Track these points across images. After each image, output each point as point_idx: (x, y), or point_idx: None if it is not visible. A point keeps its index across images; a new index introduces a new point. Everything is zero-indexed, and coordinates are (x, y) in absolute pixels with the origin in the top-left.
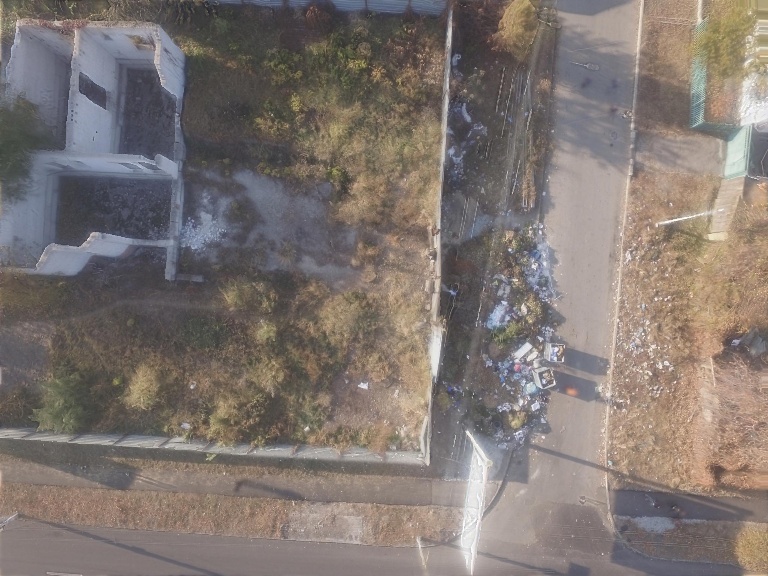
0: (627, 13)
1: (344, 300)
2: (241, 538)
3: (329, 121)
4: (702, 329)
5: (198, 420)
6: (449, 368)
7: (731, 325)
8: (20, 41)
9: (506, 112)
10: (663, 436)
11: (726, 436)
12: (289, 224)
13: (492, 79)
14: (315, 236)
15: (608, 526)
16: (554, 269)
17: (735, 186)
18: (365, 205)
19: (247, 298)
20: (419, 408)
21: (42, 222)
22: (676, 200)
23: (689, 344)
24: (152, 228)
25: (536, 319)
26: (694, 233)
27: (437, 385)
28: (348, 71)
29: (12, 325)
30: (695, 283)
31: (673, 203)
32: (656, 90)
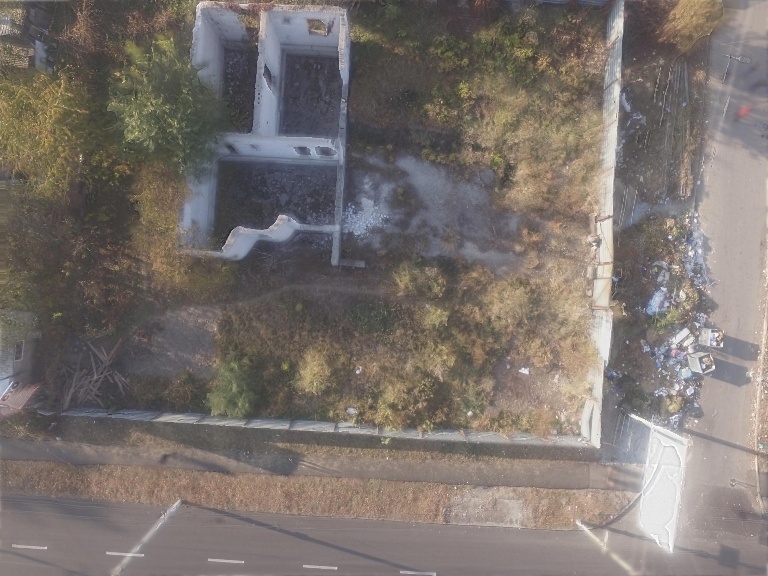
0: None
1: (509, 286)
2: (403, 523)
3: (494, 109)
4: None
5: (364, 405)
6: None
7: None
8: (201, 24)
9: (664, 102)
10: None
11: None
12: (451, 210)
13: (650, 70)
14: (477, 223)
15: (757, 508)
16: (708, 257)
17: None
18: (531, 192)
19: (419, 283)
20: (585, 392)
21: (207, 206)
22: None
23: None
24: (310, 214)
25: (693, 305)
26: None
27: None
28: (514, 60)
29: (176, 310)
30: None
31: None
32: None
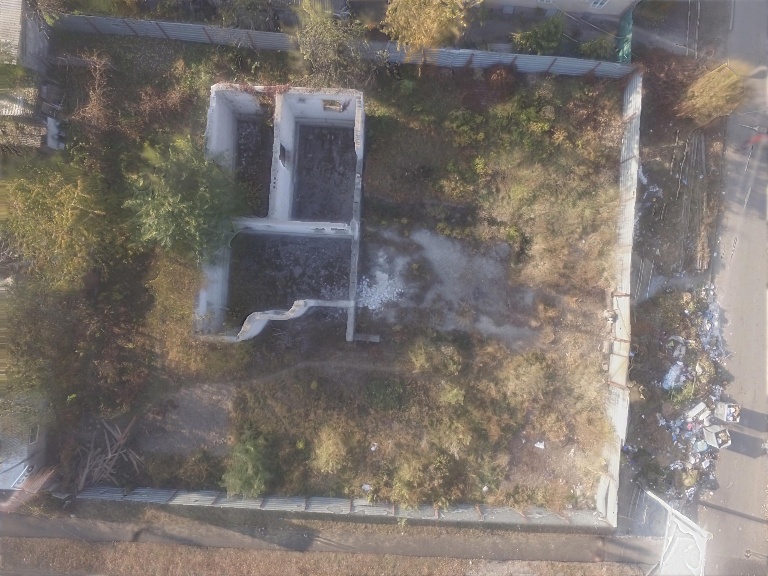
0: None
1: (524, 361)
2: None
3: (510, 183)
4: None
5: (380, 482)
6: None
7: None
8: (215, 105)
9: (680, 174)
10: None
11: None
12: (466, 284)
13: (666, 141)
14: (492, 296)
15: None
16: (724, 329)
17: None
18: (547, 268)
19: (435, 362)
20: (601, 469)
21: (221, 283)
22: None
23: None
24: (324, 286)
25: (709, 379)
26: None
27: None
28: (530, 134)
29: (190, 387)
30: None
31: None
32: None
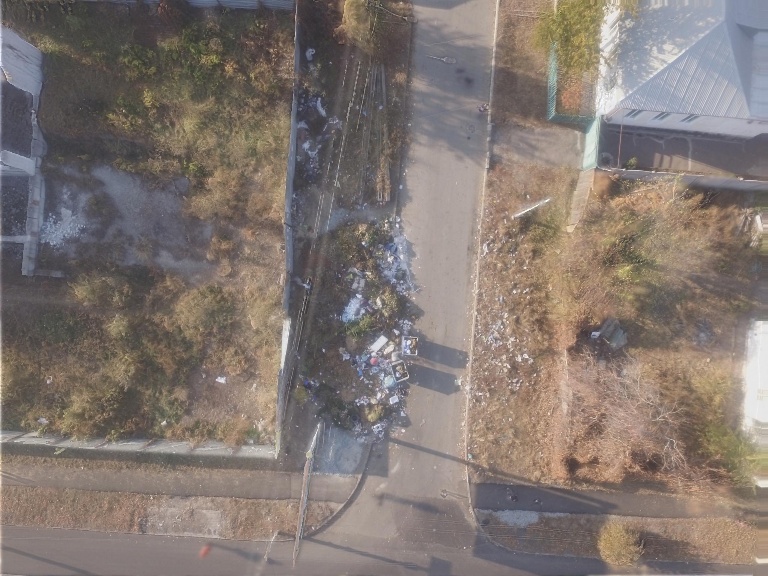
0: (484, 7)
1: (199, 294)
2: (100, 532)
3: (183, 116)
4: (559, 321)
5: (54, 415)
6: (305, 362)
7: (582, 317)
8: None
9: (361, 106)
10: (524, 429)
11: (575, 428)
12: (147, 219)
13: (348, 73)
14: (172, 231)
15: (470, 520)
16: (412, 262)
17: (588, 178)
18: (217, 200)
19: (97, 293)
20: (271, 401)
21: None
22: (533, 192)
23: (546, 336)
24: (15, 224)
25: (392, 312)
26: (552, 225)
27: (293, 379)
28: (201, 67)
29: None
30: (554, 275)
31: (530, 195)
32: (513, 83)
